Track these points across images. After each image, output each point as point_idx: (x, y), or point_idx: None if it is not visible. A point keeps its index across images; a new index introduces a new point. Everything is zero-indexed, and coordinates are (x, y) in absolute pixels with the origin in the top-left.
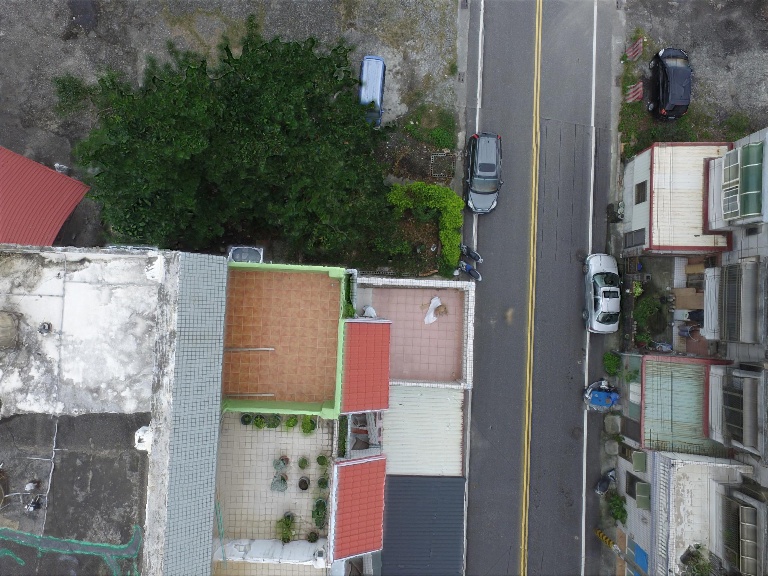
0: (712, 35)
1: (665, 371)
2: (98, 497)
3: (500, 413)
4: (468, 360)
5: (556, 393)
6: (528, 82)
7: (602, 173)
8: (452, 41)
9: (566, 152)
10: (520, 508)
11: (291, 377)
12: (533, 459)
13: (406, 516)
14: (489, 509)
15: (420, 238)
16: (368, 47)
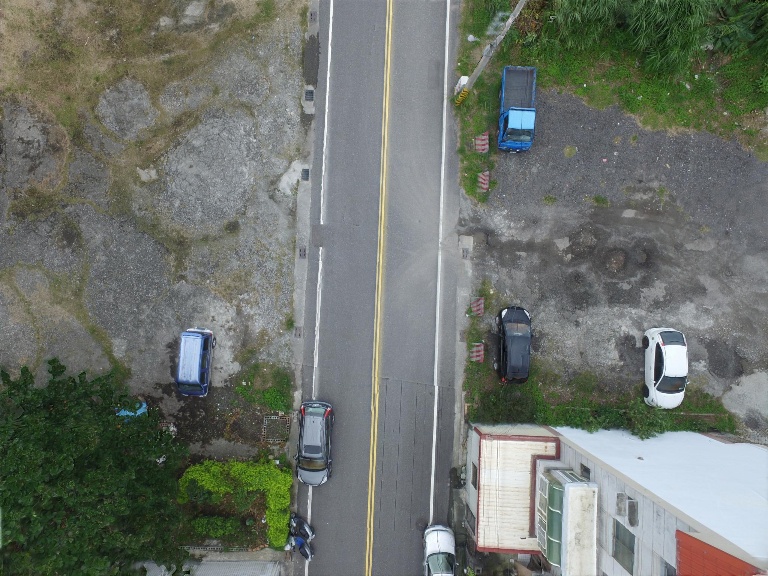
0: (561, 287)
1: None
2: None
3: None
4: None
5: None
6: (367, 339)
7: (445, 435)
8: (288, 294)
9: (406, 414)
10: None
11: None
12: None
13: None
14: None
15: (250, 509)
16: (199, 301)
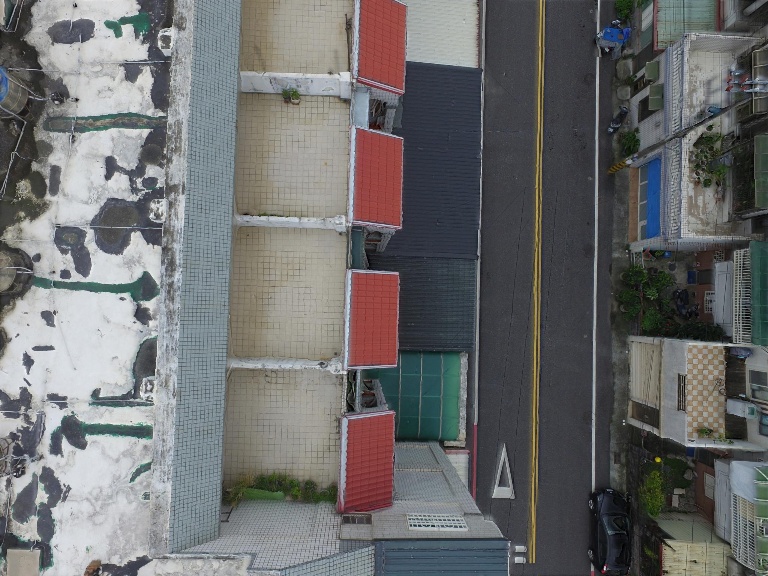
0: None
1: None
2: None
3: (513, 60)
4: None
5: (568, 40)
6: None
7: None
8: None
9: None
10: (534, 150)
11: None
12: (546, 104)
13: (424, 101)
14: (504, 152)
15: None
16: None
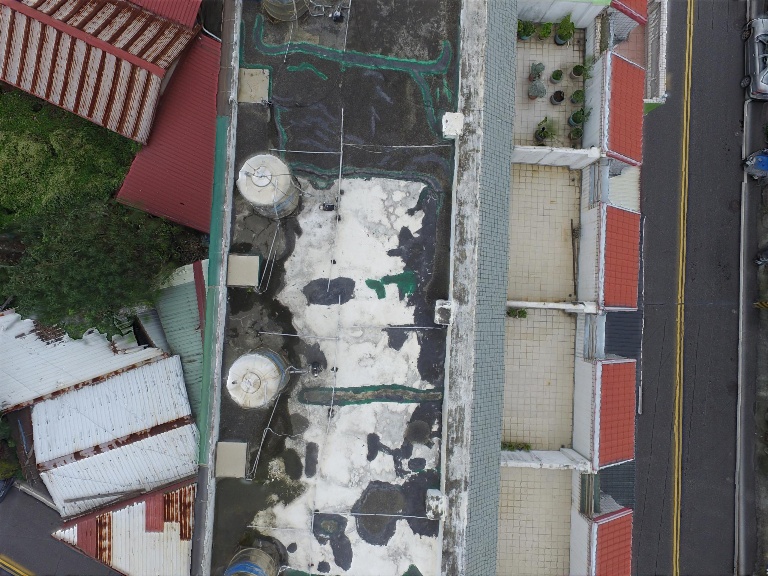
0: None
1: None
2: (403, 12)
3: (655, 184)
4: (660, 73)
5: (713, 164)
6: None
7: None
8: None
9: None
10: (676, 280)
11: None
12: (689, 231)
13: None
14: None
15: None
16: None
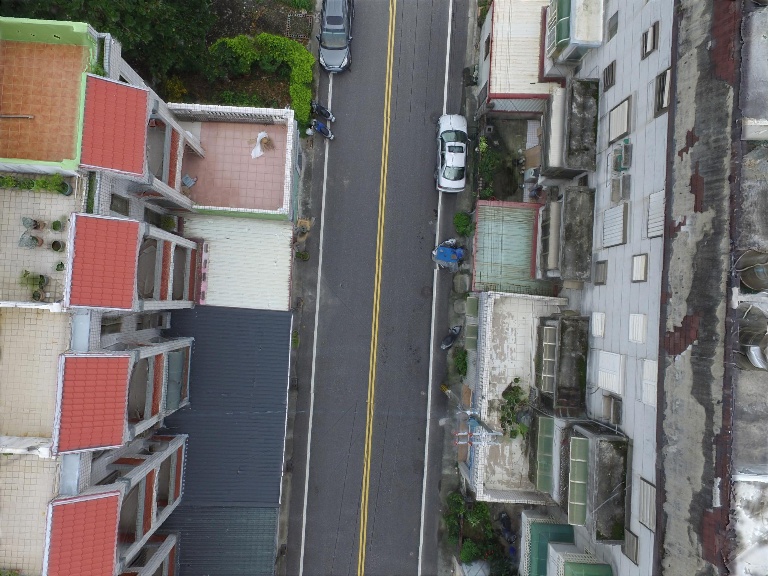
0: None
1: (496, 215)
2: None
3: (350, 271)
4: (285, 186)
5: (406, 252)
6: None
7: (459, 37)
8: None
9: (423, 15)
10: (367, 363)
11: (51, 145)
12: (382, 316)
13: (230, 347)
14: (337, 364)
15: (274, 97)
16: None
